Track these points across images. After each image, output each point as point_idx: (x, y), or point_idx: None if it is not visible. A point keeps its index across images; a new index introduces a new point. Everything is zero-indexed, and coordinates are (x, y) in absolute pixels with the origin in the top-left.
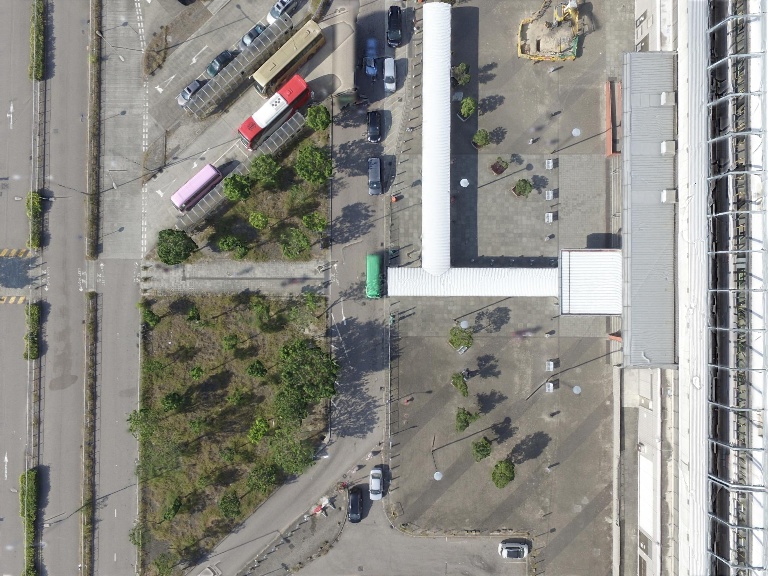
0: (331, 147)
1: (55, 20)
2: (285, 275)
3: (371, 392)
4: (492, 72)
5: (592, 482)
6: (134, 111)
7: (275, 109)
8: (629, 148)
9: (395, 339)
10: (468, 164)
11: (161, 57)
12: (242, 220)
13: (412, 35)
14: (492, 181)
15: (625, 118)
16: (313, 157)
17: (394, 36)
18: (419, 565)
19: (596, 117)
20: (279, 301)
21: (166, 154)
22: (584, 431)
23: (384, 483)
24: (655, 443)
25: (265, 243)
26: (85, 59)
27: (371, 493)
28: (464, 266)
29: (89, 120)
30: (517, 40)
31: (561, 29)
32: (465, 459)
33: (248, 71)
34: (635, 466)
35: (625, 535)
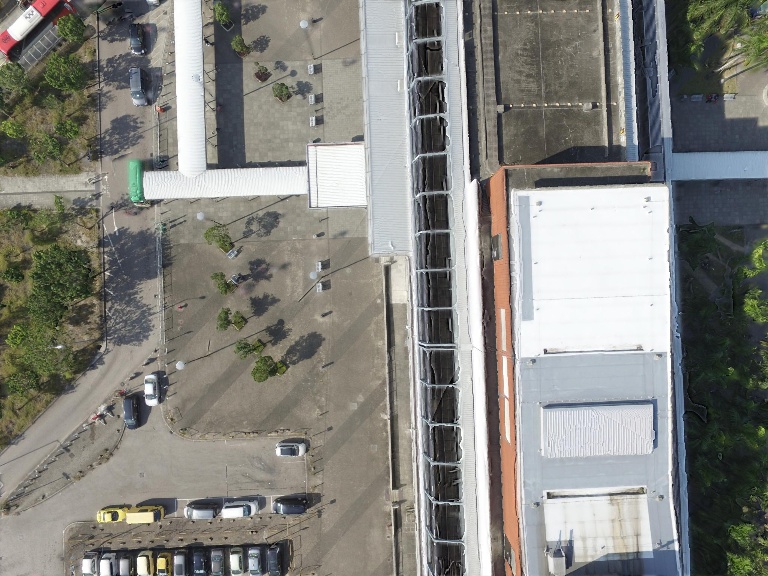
0: (98, 61)
1: None
2: (56, 188)
3: (145, 300)
4: None
5: (366, 379)
6: None
7: (29, 21)
8: (365, 41)
9: (167, 247)
10: (233, 73)
11: None
12: None
13: None
14: (257, 88)
15: (361, 12)
16: (58, 63)
17: None
18: (200, 469)
19: (357, 22)
20: (51, 214)
21: None
22: (357, 330)
23: (161, 389)
24: None
25: None
26: None
27: (146, 398)
28: None
29: None
30: None
31: None
32: (241, 362)
33: None
34: (406, 361)
35: (399, 429)
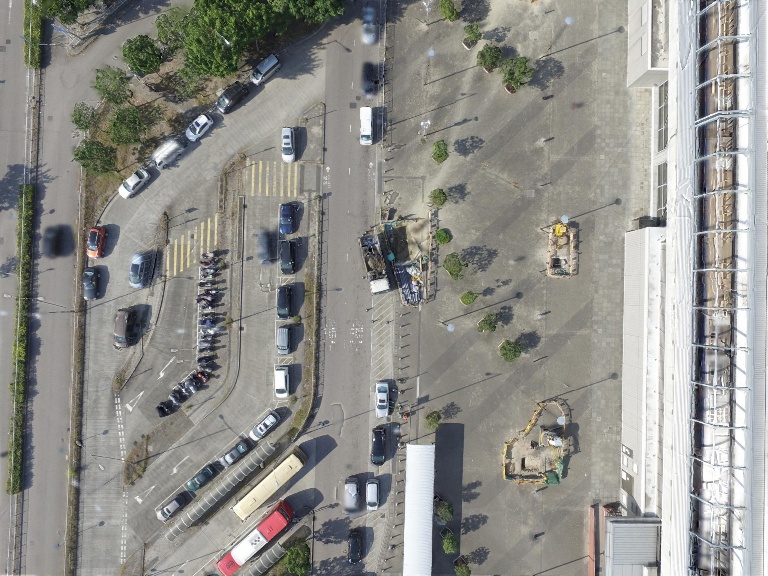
0: (312, 564)
1: (34, 428)
2: None
3: None
4: (476, 490)
5: None
6: (113, 522)
7: (255, 548)
8: None
9: None
10: None
11: (141, 468)
12: None
13: (396, 450)
14: None
15: None
16: None
17: (378, 459)
18: None
19: (580, 540)
20: None
21: (144, 566)
22: None
23: None
24: None
25: None
26: (64, 469)
27: None
28: None
29: (66, 539)
30: (502, 460)
31: (547, 448)
32: None
33: None
34: None
35: None
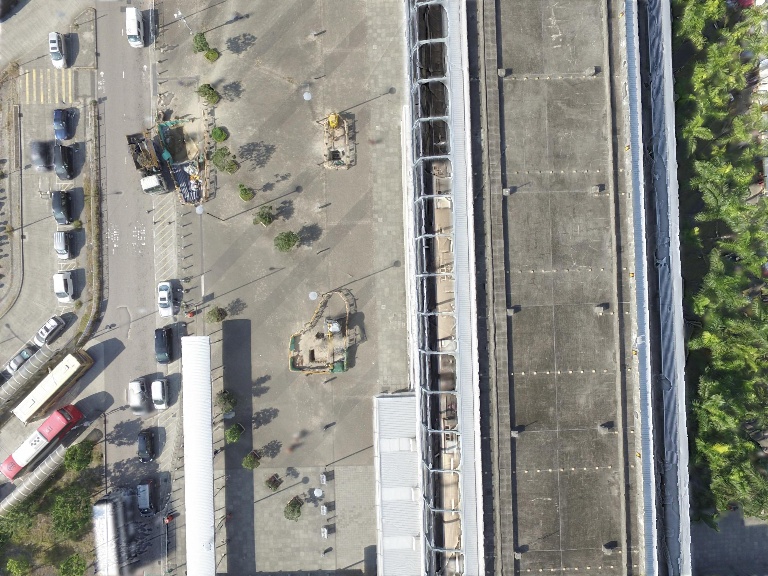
0: (105, 466)
1: None
2: None
3: None
4: (265, 385)
5: None
6: None
7: (35, 448)
8: (380, 494)
9: None
10: (244, 479)
11: None
12: (16, 545)
13: None
14: (268, 495)
15: (376, 462)
16: (65, 509)
17: (162, 357)
18: None
19: (370, 428)
20: None
21: None
22: None
23: None
24: None
25: (40, 567)
26: None
27: None
28: None
29: None
30: None
31: (333, 339)
32: None
33: (17, 394)
34: None
35: None
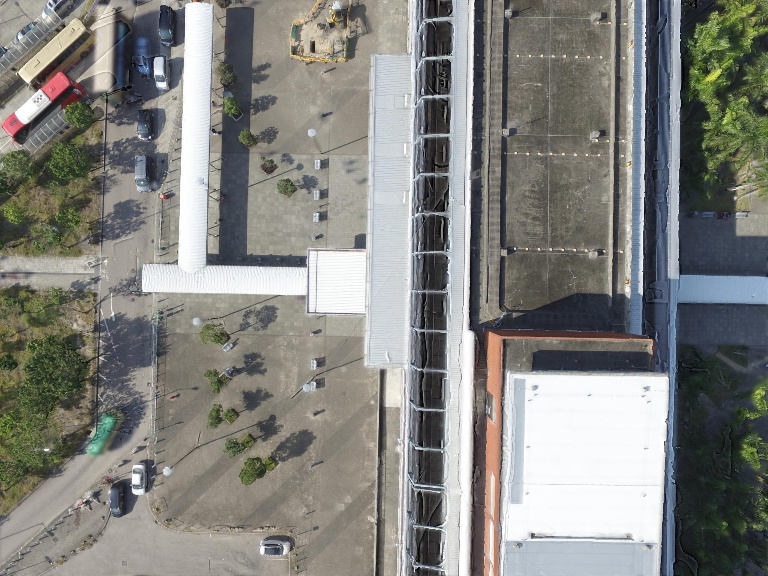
0: (104, 144)
1: None
2: (55, 270)
3: (138, 388)
4: (265, 72)
5: (355, 481)
6: None
7: (37, 105)
8: (372, 149)
9: (163, 335)
10: (239, 163)
11: None
12: None
13: None
14: (262, 180)
15: (371, 119)
16: (64, 153)
17: (165, 35)
18: (183, 561)
19: (367, 118)
20: (49, 296)
21: None
22: (348, 430)
23: (149, 478)
24: (401, 443)
25: (36, 238)
26: None
27: (133, 488)
28: (233, 264)
29: None
30: None
31: (335, 31)
32: None
33: None
34: (396, 466)
35: (385, 534)
